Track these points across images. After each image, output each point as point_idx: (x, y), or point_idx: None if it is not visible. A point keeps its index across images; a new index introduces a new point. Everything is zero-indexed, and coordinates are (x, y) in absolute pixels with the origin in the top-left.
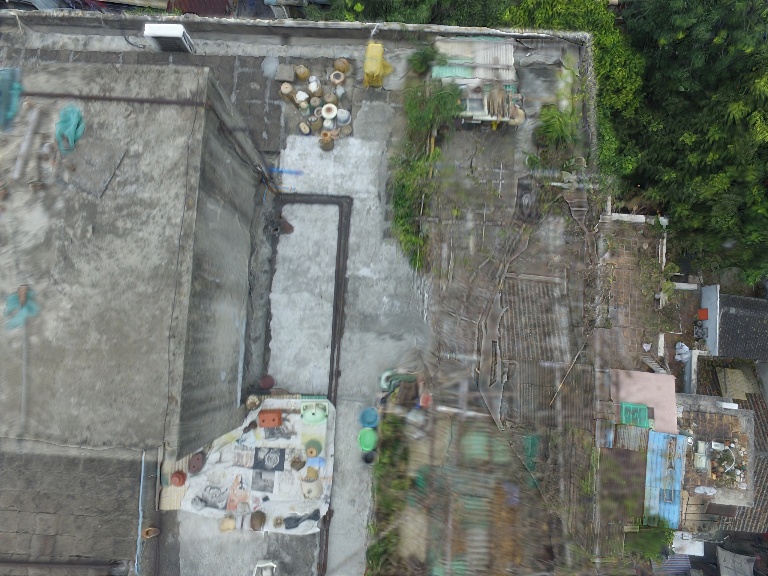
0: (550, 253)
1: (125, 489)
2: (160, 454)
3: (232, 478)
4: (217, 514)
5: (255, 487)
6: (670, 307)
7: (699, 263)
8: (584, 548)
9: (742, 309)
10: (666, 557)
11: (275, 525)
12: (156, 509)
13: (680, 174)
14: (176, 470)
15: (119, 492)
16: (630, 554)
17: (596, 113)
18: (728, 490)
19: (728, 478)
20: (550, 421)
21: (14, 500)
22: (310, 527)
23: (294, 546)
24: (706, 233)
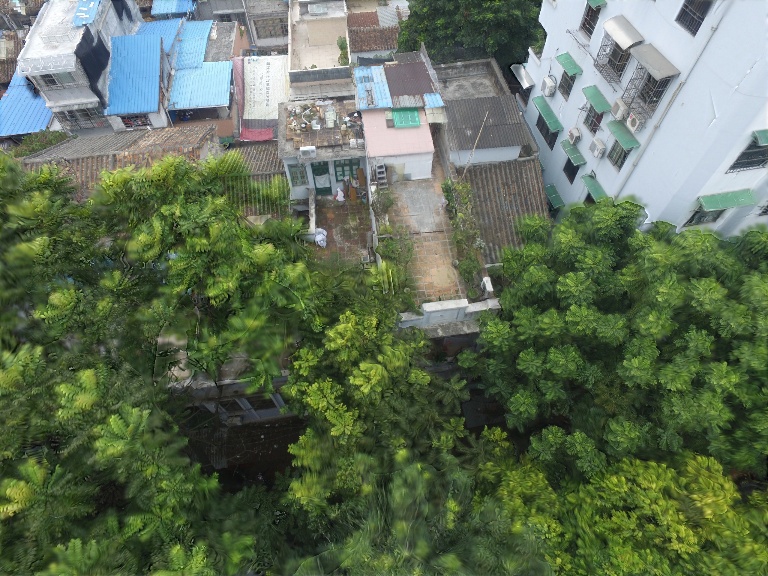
0: None
1: None
2: None
3: None
4: None
5: None
6: None
7: None
8: None
9: None
10: None
11: None
12: None
13: None
14: None
15: None
16: None
17: (556, 437)
18: None
19: None
20: (485, 100)
21: None
22: None
23: None
24: None
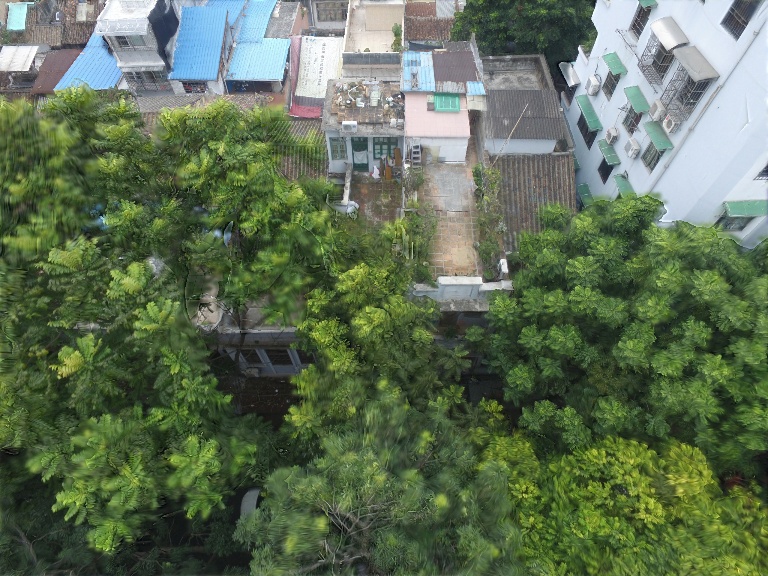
0: None
1: None
2: None
3: None
4: None
5: None
6: None
7: None
8: None
9: None
10: None
11: None
12: None
13: None
14: None
15: None
16: None
17: (547, 410)
18: None
19: None
20: (526, 93)
21: None
22: None
23: None
24: None
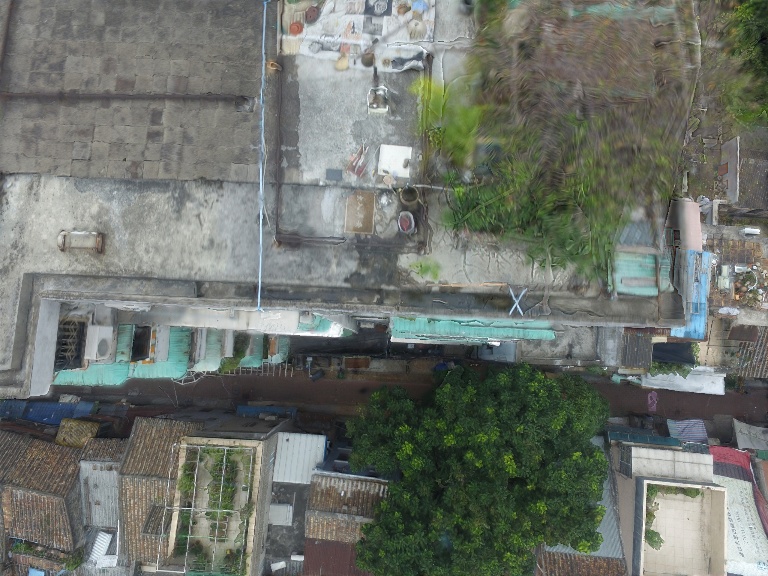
0: None
1: (249, 38)
2: (279, 9)
3: (345, 24)
4: (332, 55)
5: (366, 30)
6: (694, 140)
7: (720, 116)
8: (614, 359)
9: (761, 160)
10: (692, 366)
11: (384, 63)
12: (278, 50)
13: (703, 16)
14: (294, 21)
15: (244, 41)
16: (657, 368)
17: None
18: (750, 311)
19: (751, 297)
20: None
21: (150, 51)
22: (415, 65)
23: (400, 84)
24: (728, 73)
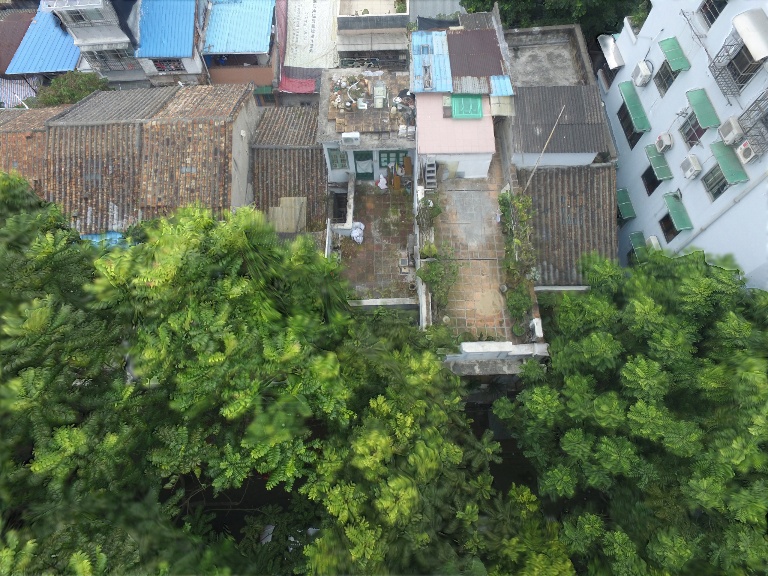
0: (555, 320)
1: None
2: None
3: None
4: None
5: None
6: None
7: None
8: None
9: None
10: None
11: None
12: None
13: None
14: None
15: None
16: None
17: (593, 527)
18: None
19: None
20: (563, 90)
21: None
22: None
23: None
24: None
